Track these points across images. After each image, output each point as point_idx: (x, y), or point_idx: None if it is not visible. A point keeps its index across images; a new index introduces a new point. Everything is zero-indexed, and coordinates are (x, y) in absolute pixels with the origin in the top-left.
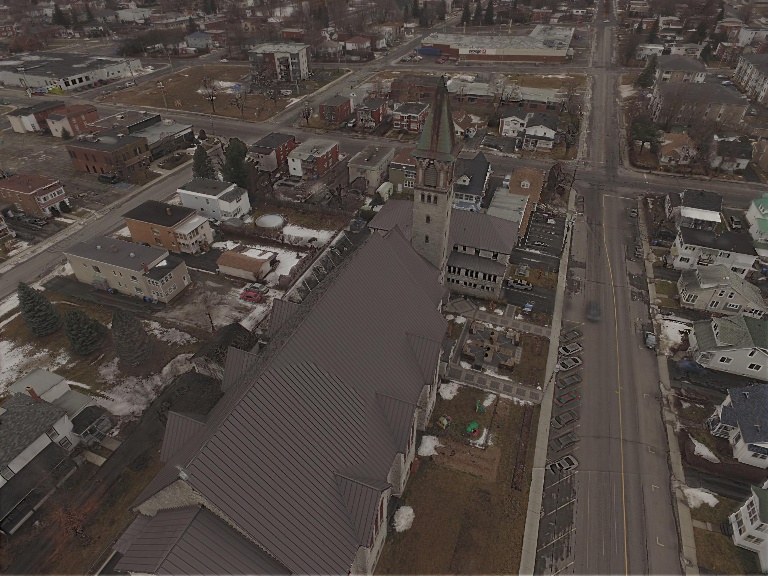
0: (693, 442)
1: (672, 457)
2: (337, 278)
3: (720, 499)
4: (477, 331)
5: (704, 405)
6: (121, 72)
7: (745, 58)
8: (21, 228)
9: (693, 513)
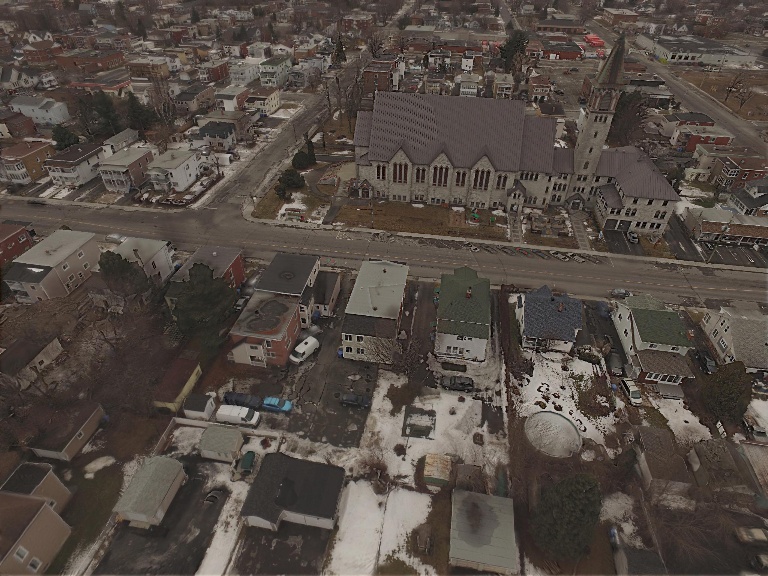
0: None
1: None
2: None
3: None
4: None
5: None
6: (728, 62)
7: None
8: None
9: None
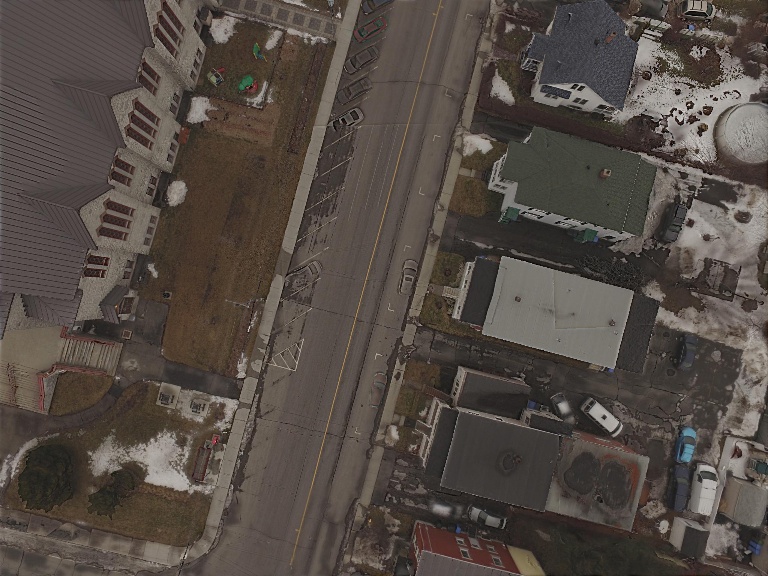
0: (496, 80)
1: (467, 100)
2: None
3: (495, 145)
4: None
5: (531, 26)
6: None
7: None
8: None
9: (463, 161)
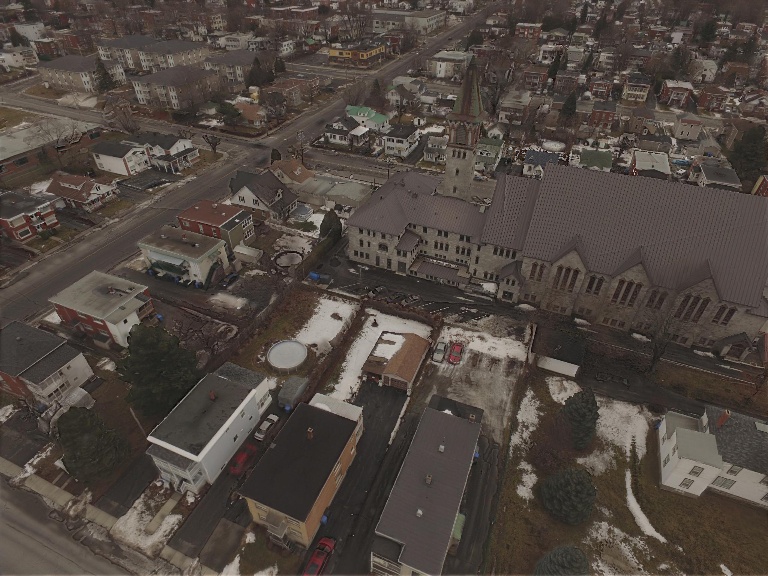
0: None
1: None
2: None
3: None
4: None
5: None
6: None
7: (108, 46)
8: None
9: None
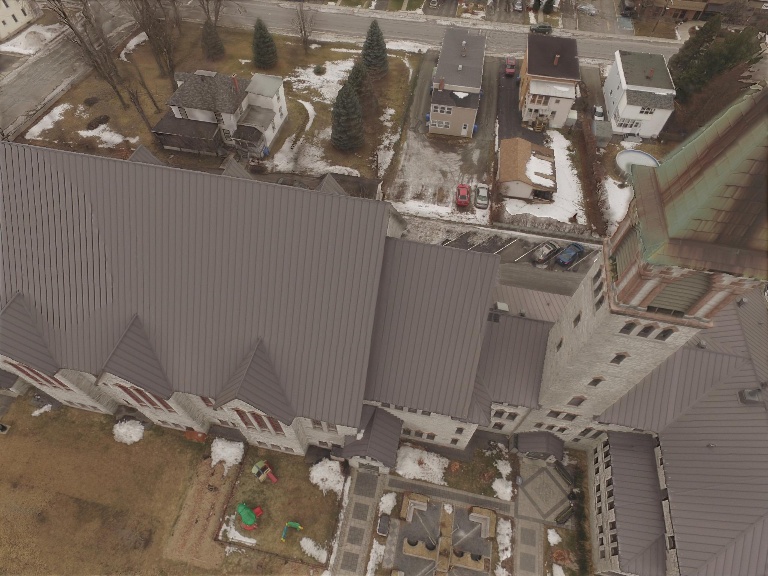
0: None
1: None
2: (224, 176)
3: None
4: (480, 524)
5: None
6: None
7: None
8: (505, 2)
9: None
